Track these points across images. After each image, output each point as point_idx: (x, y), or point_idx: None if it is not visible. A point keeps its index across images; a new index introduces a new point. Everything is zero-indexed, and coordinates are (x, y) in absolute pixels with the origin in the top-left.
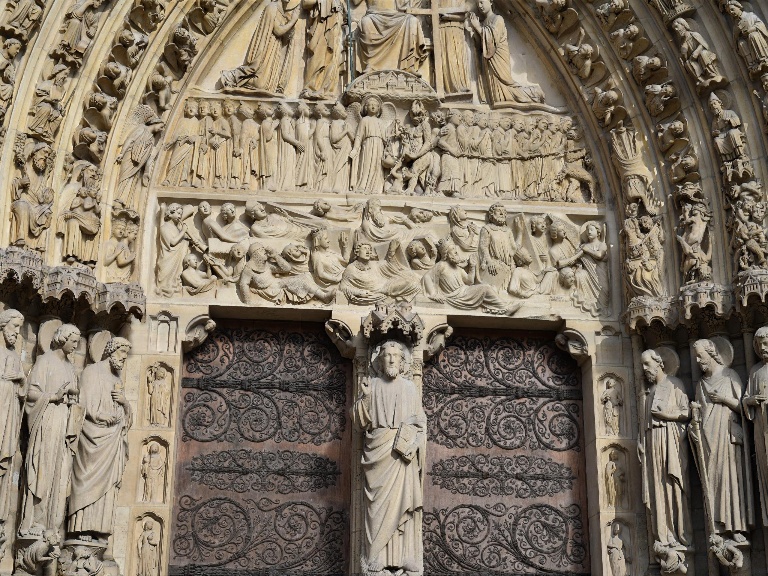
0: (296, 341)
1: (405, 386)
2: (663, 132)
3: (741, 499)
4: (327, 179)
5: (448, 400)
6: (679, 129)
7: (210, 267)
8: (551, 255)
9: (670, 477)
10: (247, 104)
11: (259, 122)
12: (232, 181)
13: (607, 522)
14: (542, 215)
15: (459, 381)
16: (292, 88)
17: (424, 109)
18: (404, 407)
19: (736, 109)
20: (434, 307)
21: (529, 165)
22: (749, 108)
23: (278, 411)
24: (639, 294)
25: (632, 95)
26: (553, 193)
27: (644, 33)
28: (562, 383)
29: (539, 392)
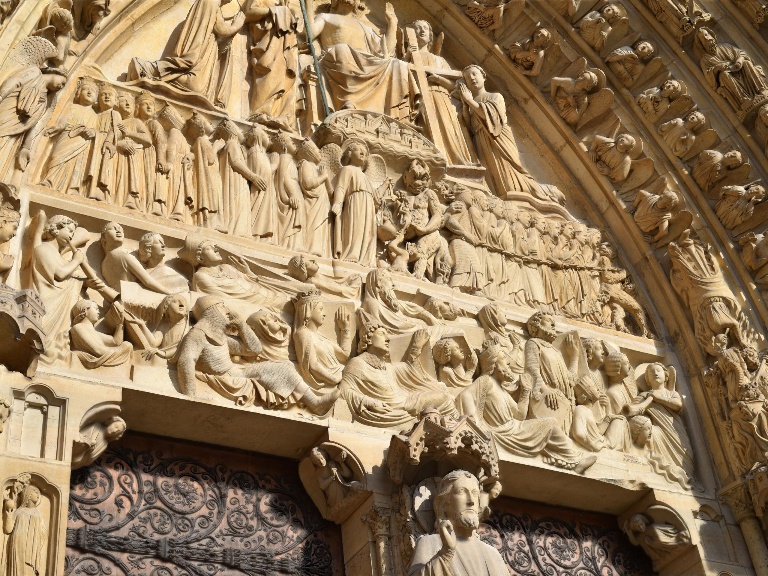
0: (245, 485)
1: (489, 549)
2: (756, 243)
3: None
4: (300, 235)
5: None
6: None
7: (123, 326)
8: (612, 398)
9: None
10: None
11: (188, 141)
12: (155, 206)
13: None
14: None
15: None
16: (233, 111)
17: (428, 173)
18: None
19: None
20: None
21: (563, 276)
22: None
23: None
24: (765, 451)
25: (693, 203)
26: (599, 317)
27: None
28: None
29: None
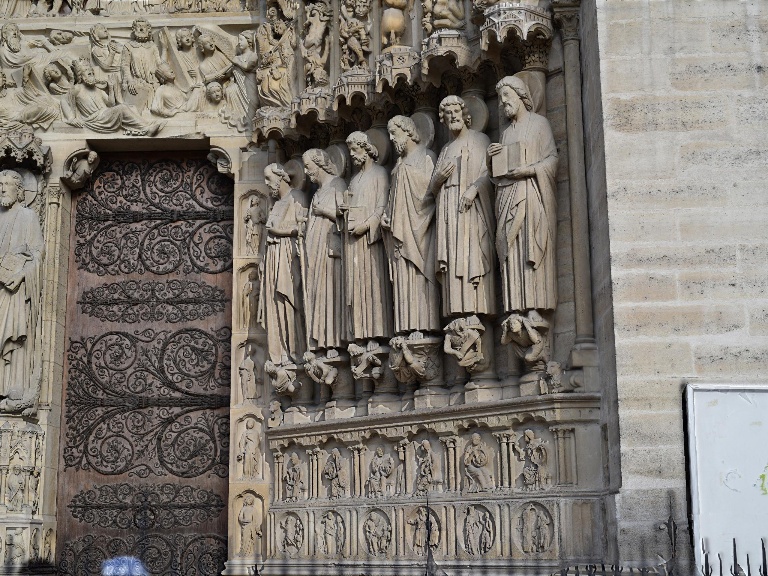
0: None
1: (21, 215)
2: None
3: (336, 314)
4: None
5: (101, 227)
6: None
7: None
8: (200, 70)
9: (281, 295)
10: None
11: None
12: None
13: (238, 343)
14: (192, 28)
15: (113, 207)
16: None
17: None
18: (14, 236)
19: None
20: (73, 132)
21: None
22: None
23: None
24: (269, 105)
25: None
26: (205, 3)
27: None
28: (220, 204)
29: (195, 214)
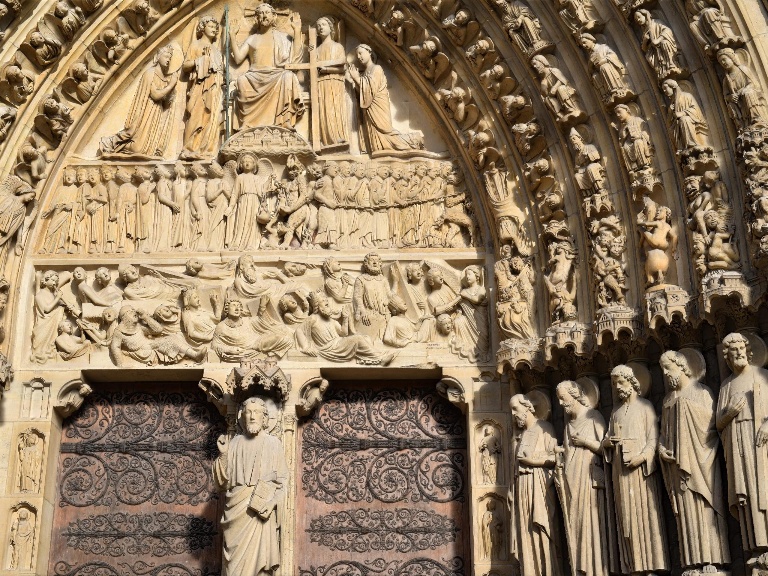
0: (176, 401)
1: (267, 442)
2: (530, 171)
3: (603, 546)
4: (202, 238)
5: (328, 455)
6: (543, 167)
7: (83, 332)
8: (429, 302)
9: (536, 525)
10: (125, 169)
11: (138, 186)
12: (108, 245)
13: (482, 574)
14: (420, 262)
15: (340, 435)
16: (172, 150)
17: (299, 163)
18: (263, 464)
19: (596, 143)
20: (307, 361)
21: (407, 212)
22: (608, 141)
23: (155, 473)
24: (509, 337)
25: (504, 136)
26: (431, 239)
27: (510, 72)
28: (446, 432)
29: (422, 442)
